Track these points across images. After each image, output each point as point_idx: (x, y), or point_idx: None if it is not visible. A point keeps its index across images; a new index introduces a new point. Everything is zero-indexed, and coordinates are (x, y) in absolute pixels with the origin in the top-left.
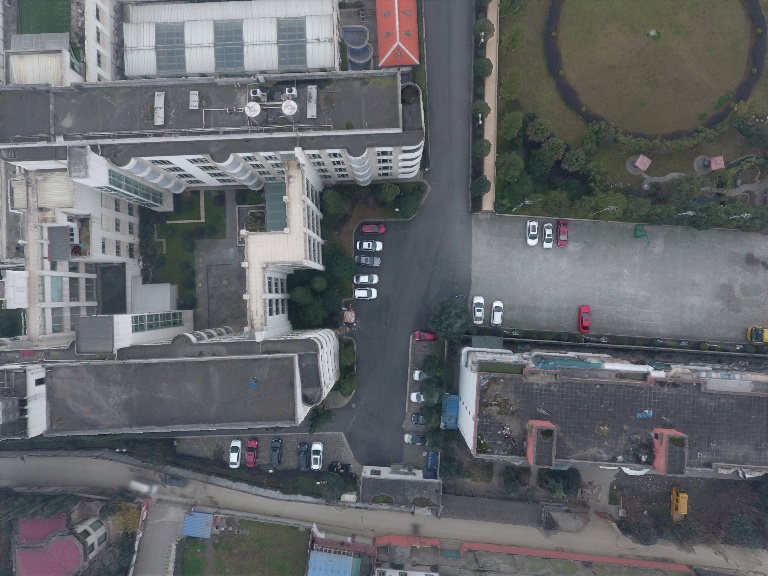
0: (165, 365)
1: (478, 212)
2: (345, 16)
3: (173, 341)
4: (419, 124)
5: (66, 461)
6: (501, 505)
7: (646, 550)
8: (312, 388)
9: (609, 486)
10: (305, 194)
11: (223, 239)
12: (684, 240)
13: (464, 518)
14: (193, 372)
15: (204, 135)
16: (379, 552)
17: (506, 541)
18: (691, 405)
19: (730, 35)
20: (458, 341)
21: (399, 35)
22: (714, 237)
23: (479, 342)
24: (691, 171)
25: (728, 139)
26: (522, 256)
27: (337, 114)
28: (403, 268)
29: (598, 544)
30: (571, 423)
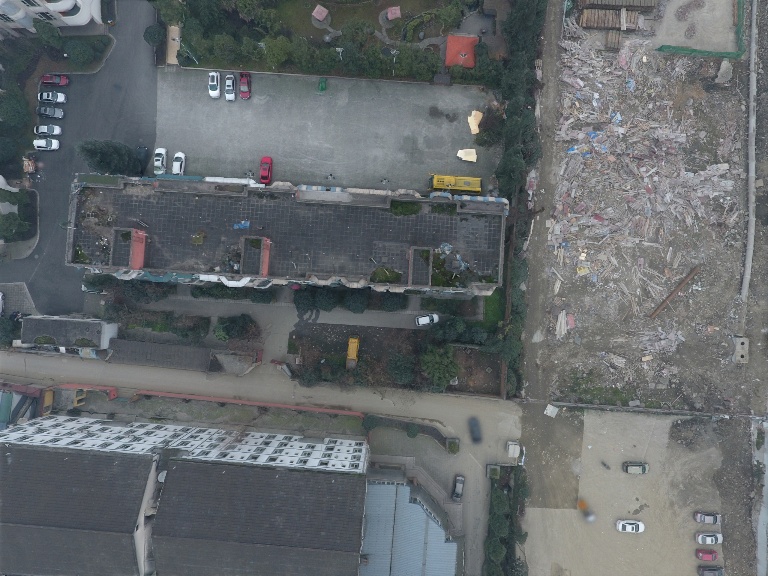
0: None
1: (162, 65)
2: None
3: None
4: None
5: None
6: (170, 350)
7: (323, 398)
8: None
9: (288, 336)
10: None
11: None
12: (368, 93)
13: (134, 363)
14: None
15: None
16: None
17: (184, 390)
18: (289, 216)
19: None
20: None
21: None
22: (398, 90)
23: None
24: (376, 25)
25: None
26: (207, 109)
27: None
28: (88, 121)
29: (275, 393)
30: (169, 234)
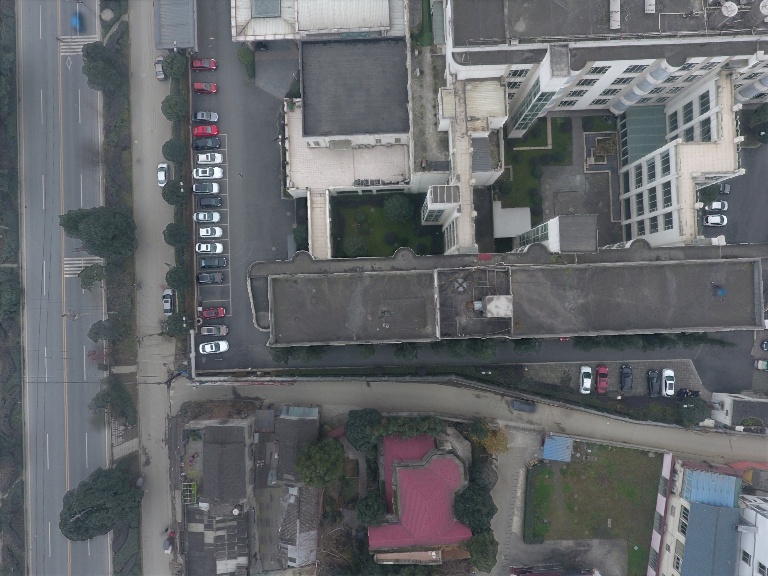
0: (622, 270)
1: None
2: None
3: (631, 245)
4: None
5: (412, 387)
6: None
7: None
8: None
9: None
10: (733, 104)
11: (569, 166)
12: None
13: None
14: (650, 277)
15: (665, 38)
16: None
17: None
18: None
19: None
20: None
21: None
22: None
23: None
24: None
25: None
26: None
27: None
28: (750, 196)
29: None
30: None
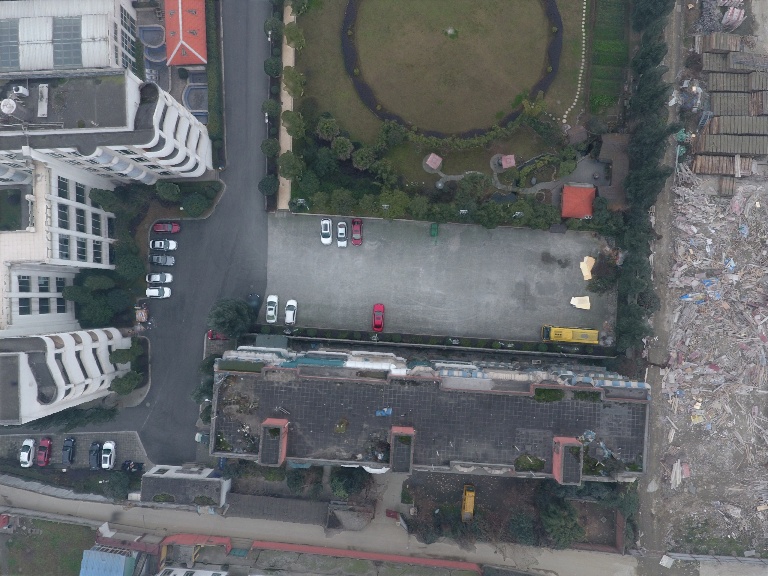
0: None
1: (273, 211)
2: (142, 15)
3: None
4: (152, 123)
5: None
6: (287, 504)
7: (438, 549)
8: (50, 387)
9: (402, 485)
10: (52, 193)
11: None
12: (480, 239)
13: (250, 517)
14: None
15: None
16: (170, 551)
17: (298, 540)
18: (431, 403)
19: (527, 34)
20: (247, 340)
21: (182, 34)
22: (510, 236)
23: (263, 341)
24: (487, 170)
25: (525, 138)
26: (318, 255)
27: (69, 113)
28: (198, 267)
29: (390, 543)
30: (311, 421)
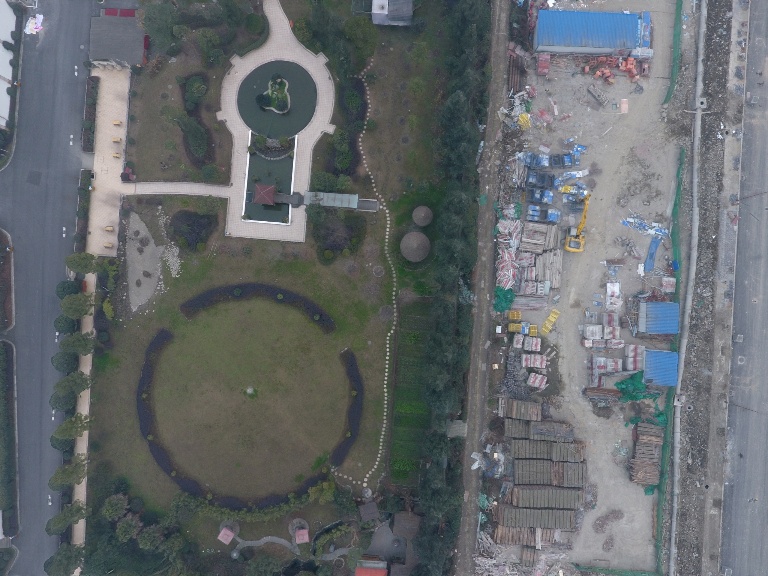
0: None
1: None
2: None
3: None
4: None
5: None
6: None
7: None
8: None
9: None
10: None
11: None
12: None
13: None
14: None
15: None
16: None
17: None
18: None
19: (328, 394)
20: None
21: None
22: None
23: None
24: (286, 535)
25: None
26: None
27: None
28: None
29: None
30: None
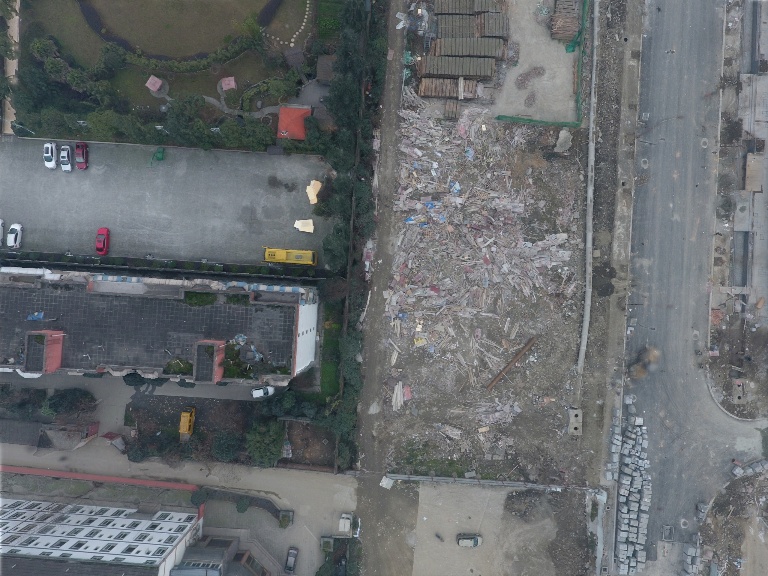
0: None
1: None
2: None
3: None
4: None
5: None
6: (2, 424)
7: (159, 471)
8: None
9: (125, 408)
10: None
11: None
12: (207, 163)
13: None
14: None
15: None
16: None
17: (21, 462)
18: (83, 307)
19: None
20: None
21: None
22: (237, 160)
23: None
24: (215, 94)
25: (252, 62)
26: (44, 179)
27: None
28: None
29: (112, 465)
30: None
